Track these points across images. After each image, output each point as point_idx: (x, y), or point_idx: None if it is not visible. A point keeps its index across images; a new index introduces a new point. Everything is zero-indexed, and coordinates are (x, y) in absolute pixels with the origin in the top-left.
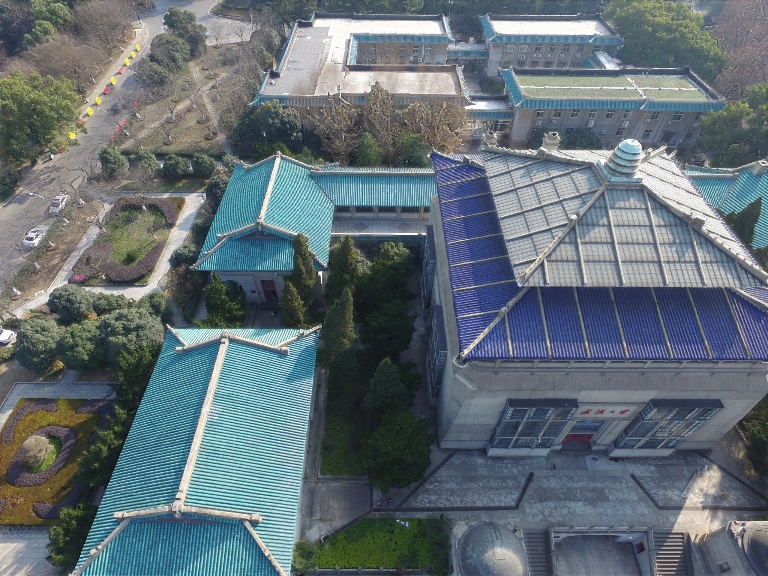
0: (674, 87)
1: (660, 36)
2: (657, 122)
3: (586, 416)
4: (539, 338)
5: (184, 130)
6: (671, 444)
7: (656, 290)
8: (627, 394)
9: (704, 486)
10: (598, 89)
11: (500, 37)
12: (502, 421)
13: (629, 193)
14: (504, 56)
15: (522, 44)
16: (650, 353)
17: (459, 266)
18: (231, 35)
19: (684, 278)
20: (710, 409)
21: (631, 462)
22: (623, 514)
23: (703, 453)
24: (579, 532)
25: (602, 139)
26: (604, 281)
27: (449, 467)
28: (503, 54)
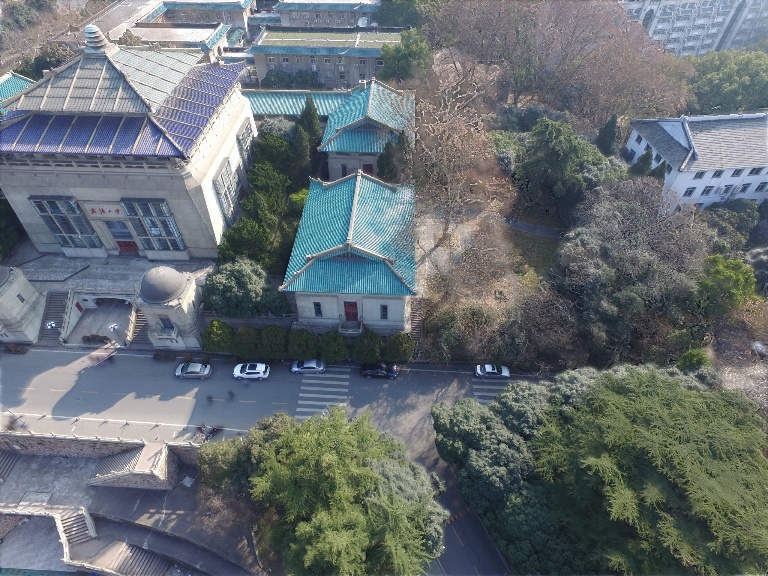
0: (388, 40)
1: (395, 2)
2: (365, 67)
3: (99, 216)
4: (12, 142)
5: (5, 72)
6: (179, 247)
7: (103, 120)
8: (101, 192)
9: (199, 275)
10: (324, 41)
11: (283, 5)
12: (40, 216)
13: (98, 61)
14: (292, 22)
15: (303, 11)
16: (74, 150)
17: (11, 112)
18: (84, 6)
19: (103, 107)
20: (157, 204)
21: (162, 263)
22: (130, 286)
23: (216, 260)
24: (93, 294)
25: (330, 82)
26: (53, 108)
27: (37, 261)
28: (290, 20)
